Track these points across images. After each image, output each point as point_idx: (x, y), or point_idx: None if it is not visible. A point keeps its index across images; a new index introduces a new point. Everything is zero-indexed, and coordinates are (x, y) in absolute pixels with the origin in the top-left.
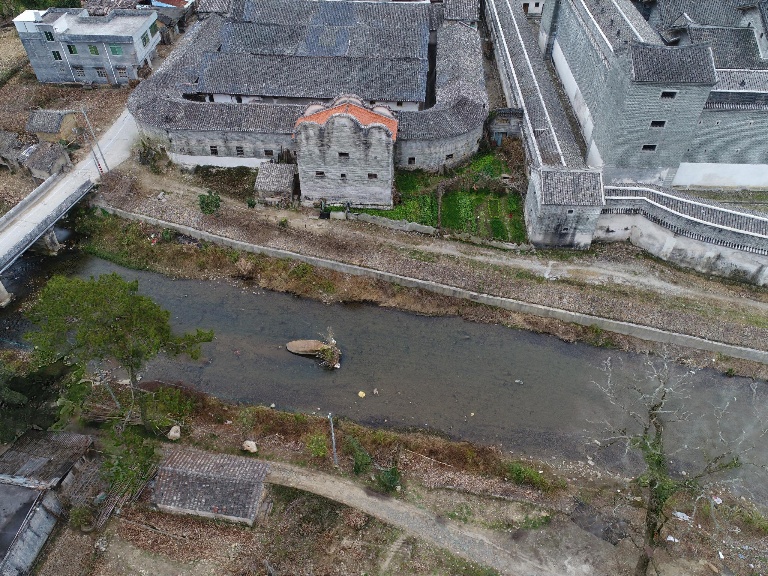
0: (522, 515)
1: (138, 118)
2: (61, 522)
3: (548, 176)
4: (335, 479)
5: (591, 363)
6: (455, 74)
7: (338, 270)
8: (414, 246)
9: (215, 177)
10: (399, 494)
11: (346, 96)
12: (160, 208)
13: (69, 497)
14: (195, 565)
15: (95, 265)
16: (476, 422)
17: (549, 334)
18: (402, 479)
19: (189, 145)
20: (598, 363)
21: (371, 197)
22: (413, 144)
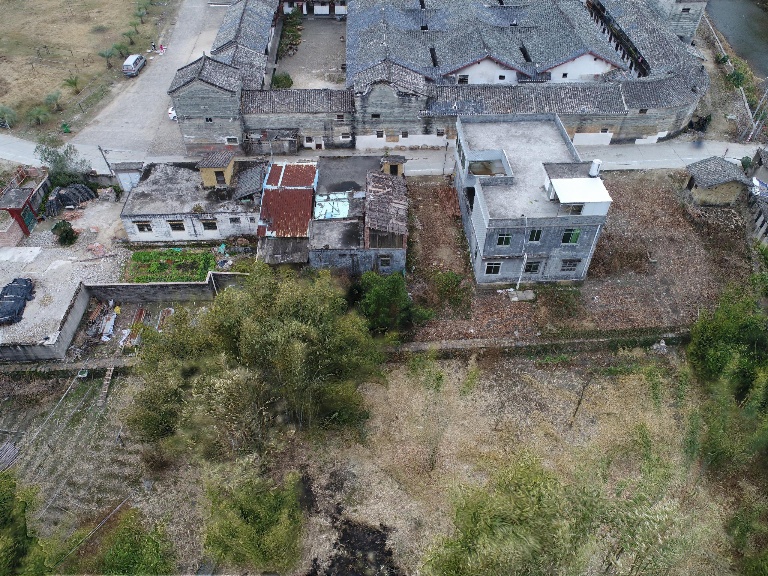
0: None
1: None
2: None
3: None
4: None
5: (711, 2)
6: None
7: None
8: None
9: None
10: None
11: None
12: None
13: None
14: None
15: None
16: None
17: None
18: None
19: None
20: (710, 1)
21: None
22: None
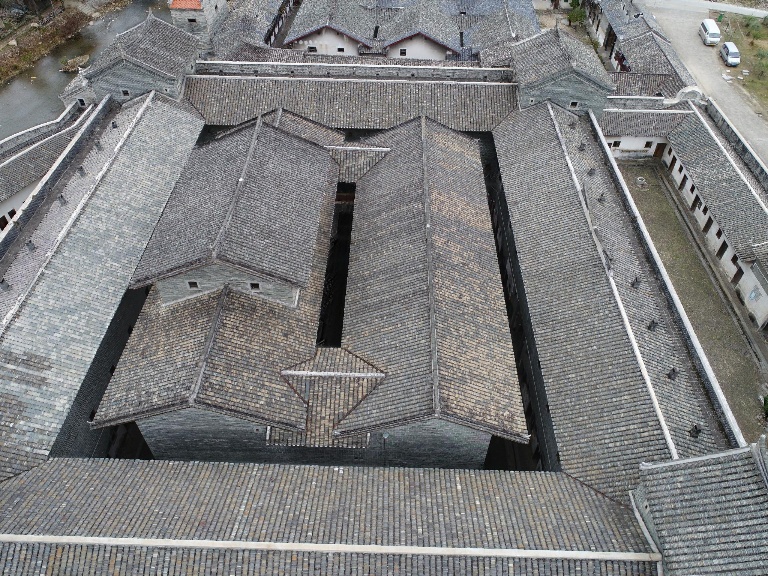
0: None
1: None
2: None
3: None
4: None
5: None
6: None
7: None
8: None
9: None
10: None
11: None
12: None
13: None
14: None
15: None
16: None
17: None
18: None
19: None
20: None
21: None
22: None
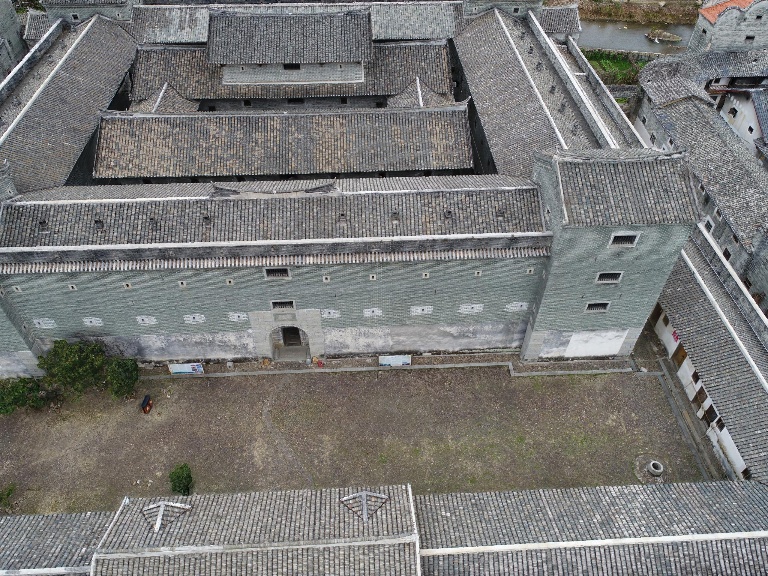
0: None
1: None
2: None
3: None
4: (619, 1)
5: None
6: None
7: None
8: None
9: None
10: None
11: None
12: None
13: None
14: None
15: None
16: None
17: None
18: (591, 2)
19: None
20: None
21: None
22: None
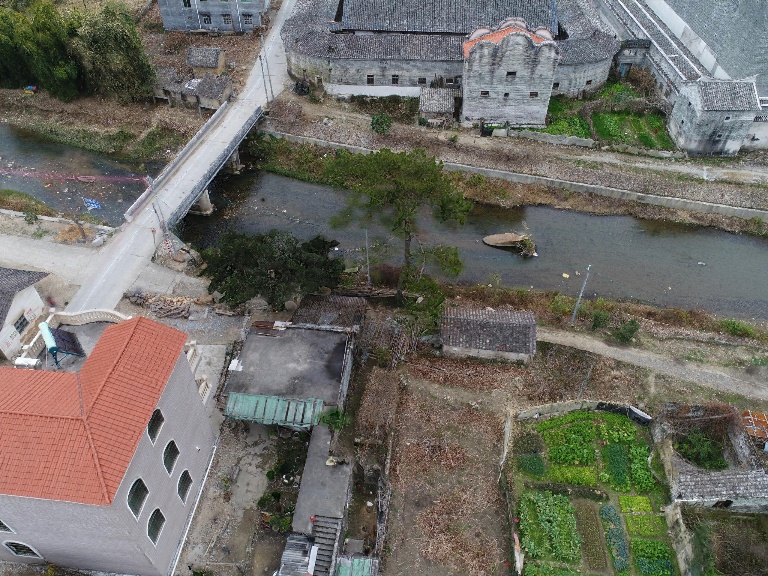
0: (749, 355)
1: (299, 50)
2: (358, 365)
3: (707, 86)
4: (575, 335)
5: (759, 249)
6: (577, 12)
7: (509, 180)
8: (577, 157)
9: (371, 105)
10: (636, 344)
11: (513, 19)
12: (328, 131)
13: (367, 342)
14: (491, 393)
15: (279, 181)
16: (675, 294)
17: (715, 227)
18: (633, 334)
19: (347, 75)
20: (765, 248)
21: (528, 116)
22: (560, 69)
